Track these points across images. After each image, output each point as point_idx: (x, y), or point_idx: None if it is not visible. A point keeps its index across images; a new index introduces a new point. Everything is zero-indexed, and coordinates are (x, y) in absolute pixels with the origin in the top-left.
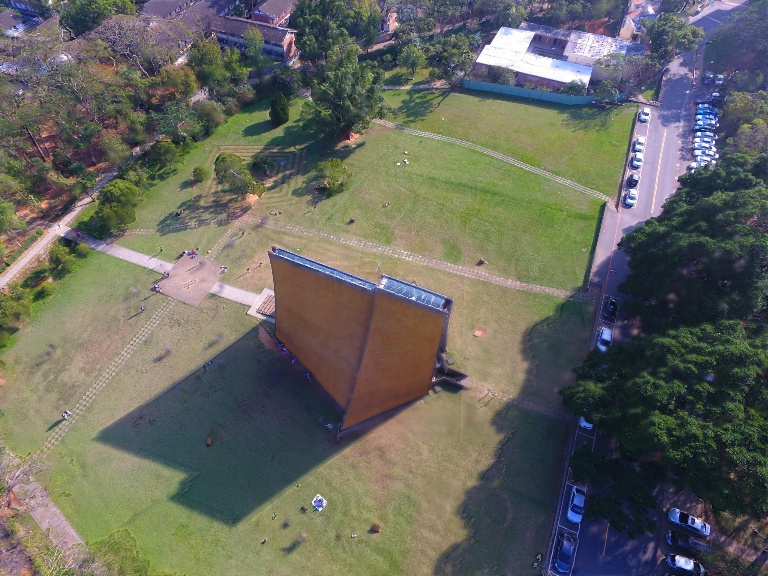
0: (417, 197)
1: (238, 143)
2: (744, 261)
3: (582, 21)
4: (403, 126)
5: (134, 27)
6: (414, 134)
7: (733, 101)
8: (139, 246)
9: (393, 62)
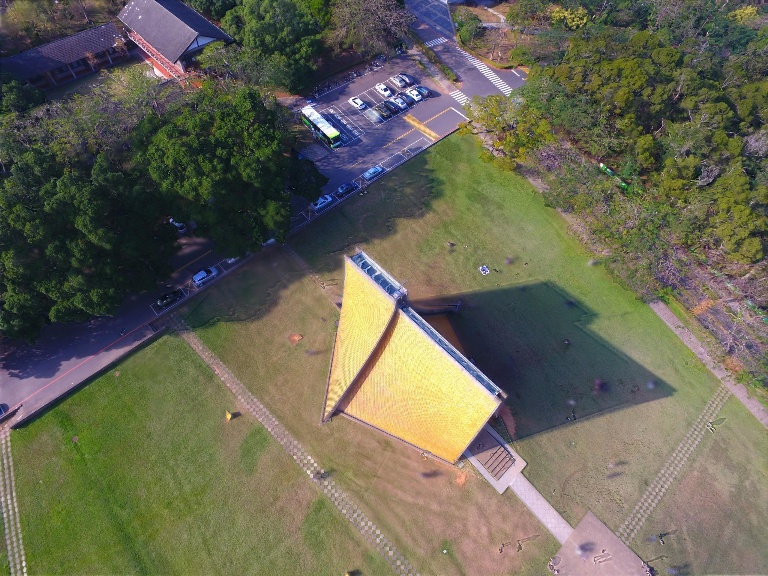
0: None
1: None
2: None
3: None
4: None
5: None
6: None
7: None
8: None
9: None
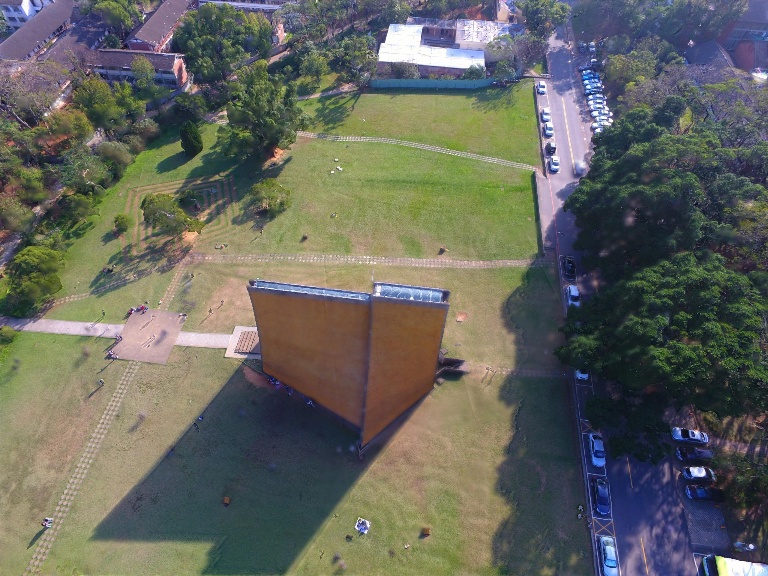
0: (361, 201)
1: (155, 182)
2: (677, 199)
3: (461, 10)
4: (325, 134)
5: (0, 74)
6: (338, 140)
7: (612, 64)
8: (75, 315)
9: (294, 73)
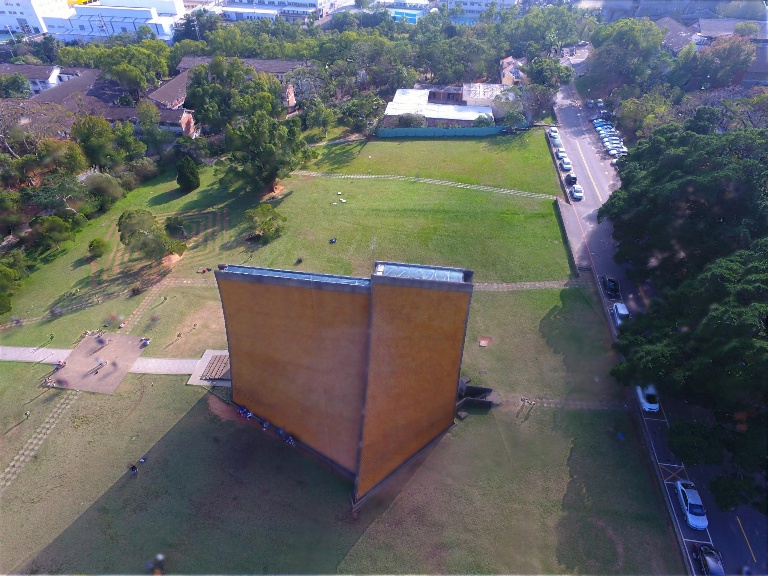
0: (365, 228)
1: None
2: (740, 186)
3: (467, 79)
4: (329, 173)
5: None
6: (342, 178)
7: (625, 107)
8: (18, 339)
9: None
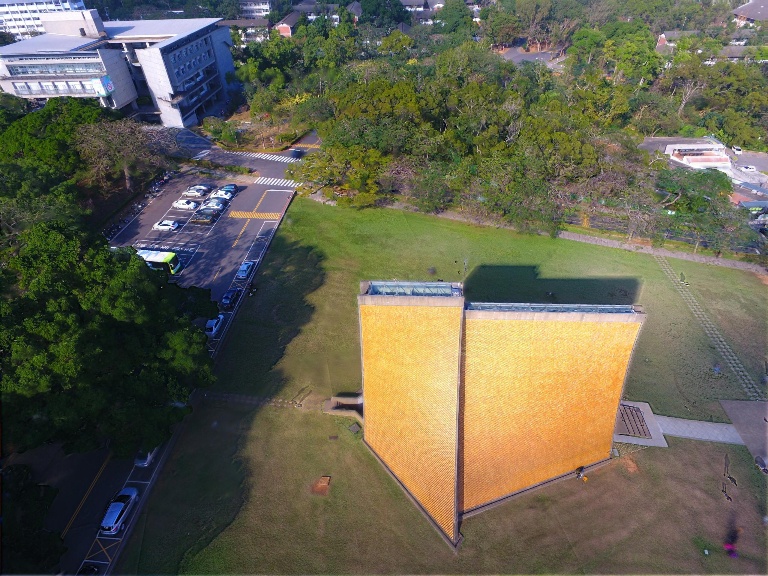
0: None
1: None
2: None
3: None
4: None
5: None
6: None
7: None
8: None
9: None
